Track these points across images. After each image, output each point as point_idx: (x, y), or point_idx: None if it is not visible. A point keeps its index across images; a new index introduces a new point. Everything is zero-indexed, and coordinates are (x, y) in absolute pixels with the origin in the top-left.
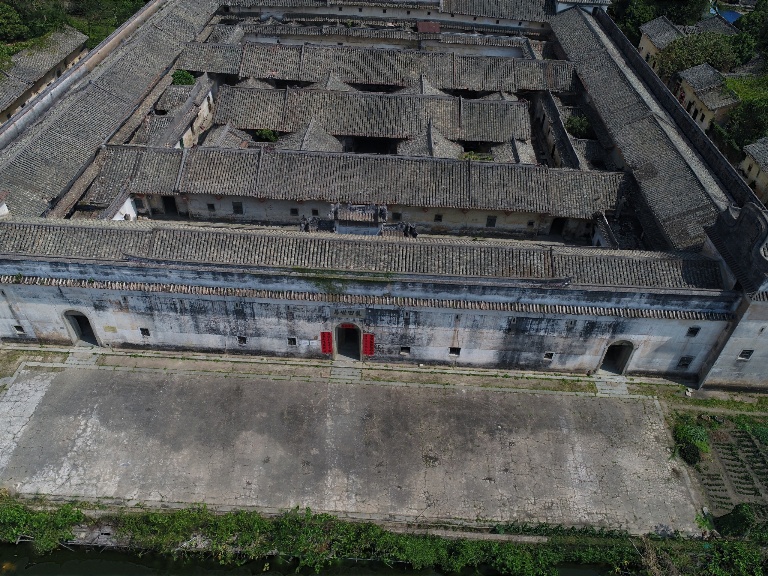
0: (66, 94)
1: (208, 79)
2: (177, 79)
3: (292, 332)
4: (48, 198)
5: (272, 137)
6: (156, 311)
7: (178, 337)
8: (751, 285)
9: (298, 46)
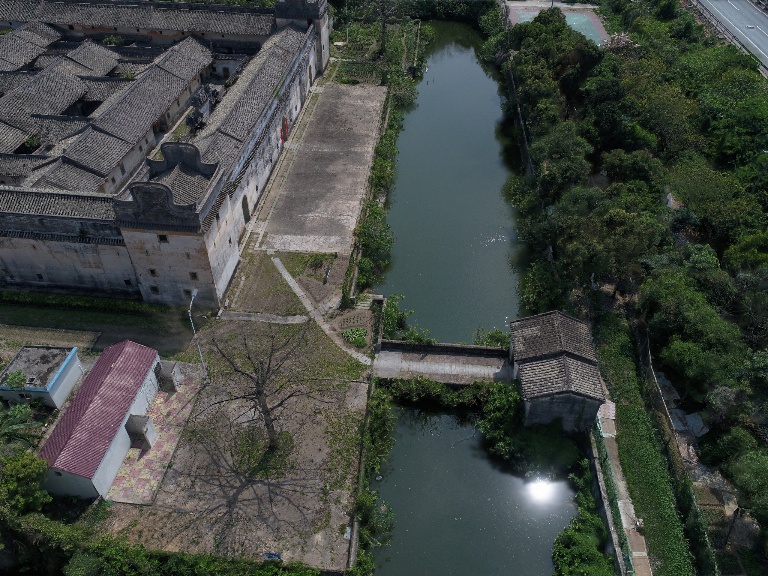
0: None
1: None
2: None
3: None
4: None
5: None
6: None
7: None
8: (316, 15)
9: None
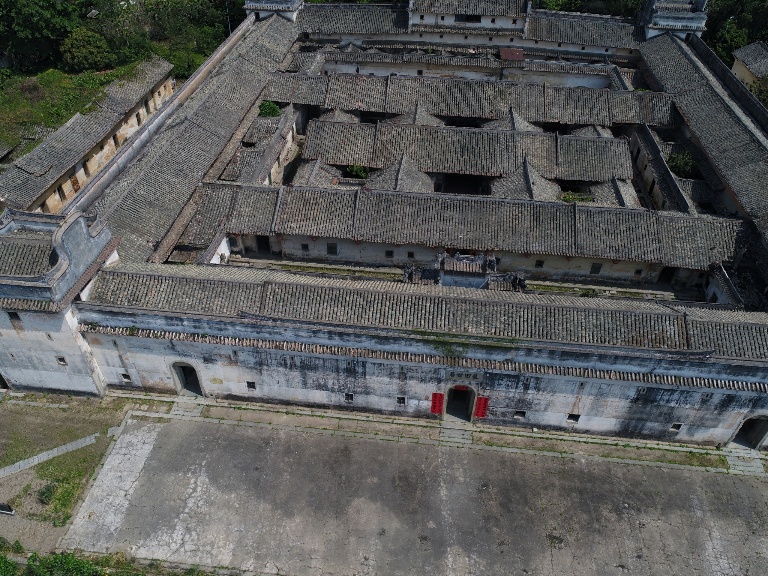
0: (162, 129)
1: (293, 110)
2: (264, 110)
3: (402, 392)
4: (153, 242)
5: (362, 173)
6: (265, 366)
7: (284, 391)
8: None
9: (384, 77)
